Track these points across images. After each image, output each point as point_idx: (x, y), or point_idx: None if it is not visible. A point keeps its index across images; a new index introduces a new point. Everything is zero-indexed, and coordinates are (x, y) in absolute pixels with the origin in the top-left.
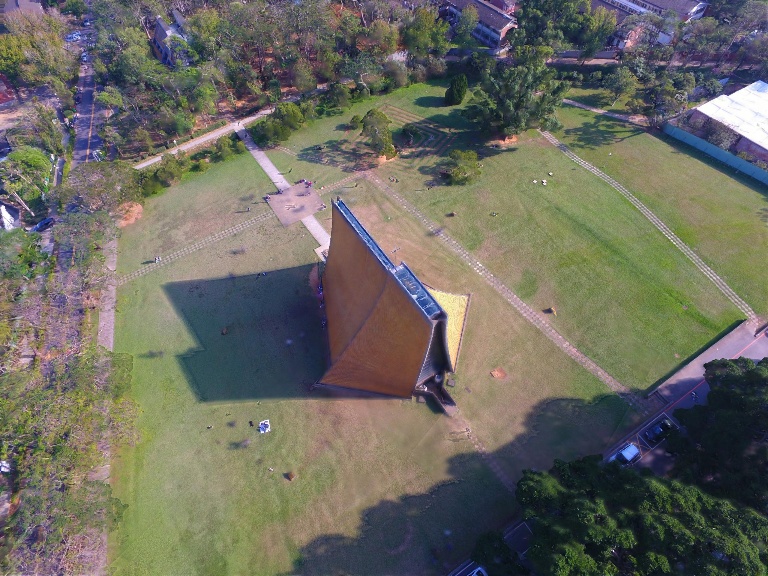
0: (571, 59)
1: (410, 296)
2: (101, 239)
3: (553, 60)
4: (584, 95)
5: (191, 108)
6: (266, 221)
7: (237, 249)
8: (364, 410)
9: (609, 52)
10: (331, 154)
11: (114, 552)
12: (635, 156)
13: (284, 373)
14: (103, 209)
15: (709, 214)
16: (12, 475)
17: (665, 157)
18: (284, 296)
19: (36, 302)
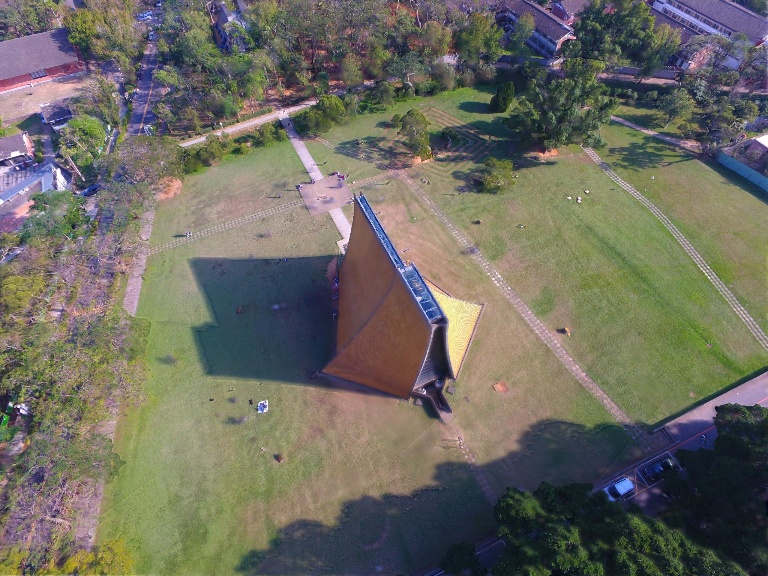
0: (628, 76)
1: (414, 297)
2: (139, 209)
3: (608, 75)
4: (636, 114)
5: (240, 93)
6: (295, 209)
7: (264, 233)
8: (361, 404)
9: (670, 72)
10: (368, 150)
11: (108, 503)
12: (681, 182)
13: (289, 358)
14: (147, 181)
15: (752, 251)
16: (29, 418)
17: (713, 187)
18: (301, 283)
19: (71, 261)
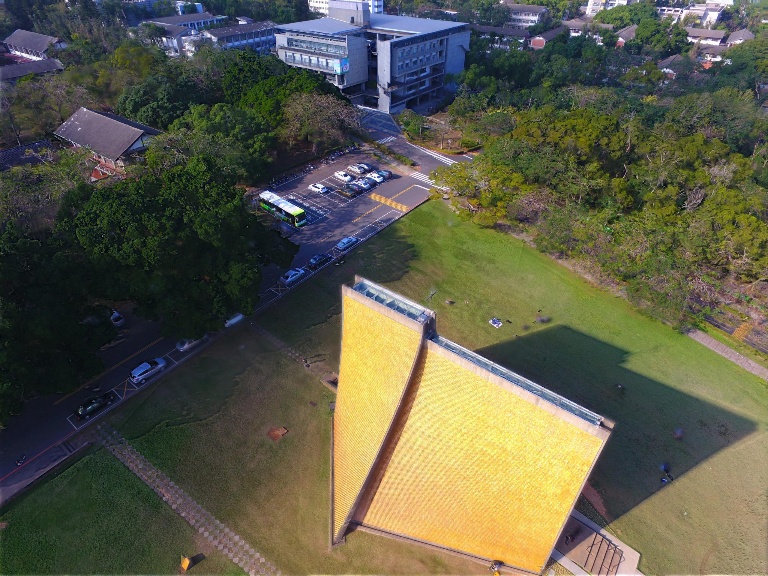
0: None
1: None
2: None
3: None
4: None
5: None
6: None
7: (760, 521)
8: None
9: None
10: None
11: (528, 247)
12: None
13: (517, 364)
14: None
15: None
16: None
17: None
18: None
19: None
